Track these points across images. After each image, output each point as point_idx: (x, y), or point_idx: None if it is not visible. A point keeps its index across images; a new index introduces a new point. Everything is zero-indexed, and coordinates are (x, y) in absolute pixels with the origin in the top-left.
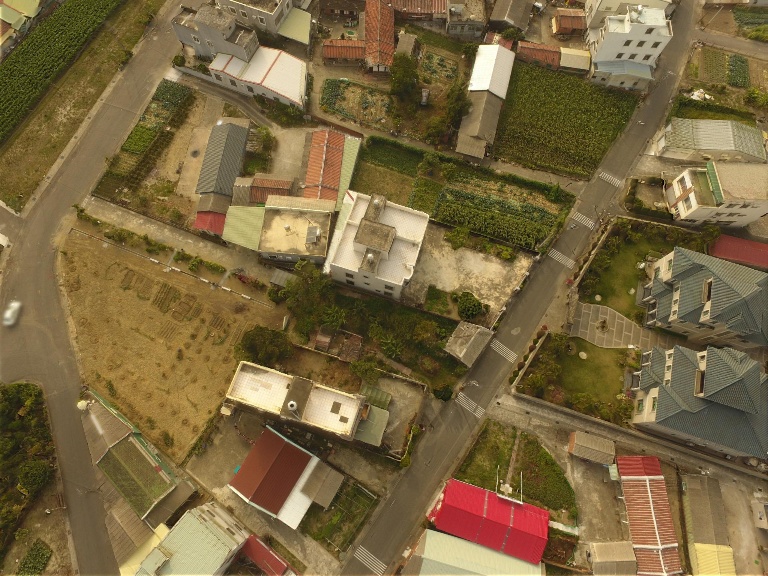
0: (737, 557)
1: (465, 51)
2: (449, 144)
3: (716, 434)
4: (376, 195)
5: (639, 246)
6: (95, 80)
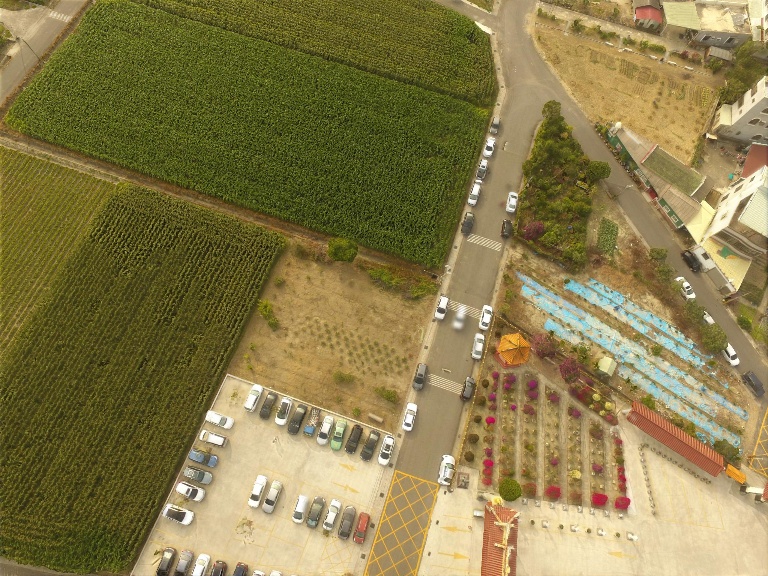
0: None
1: None
2: None
3: None
4: None
5: None
6: None
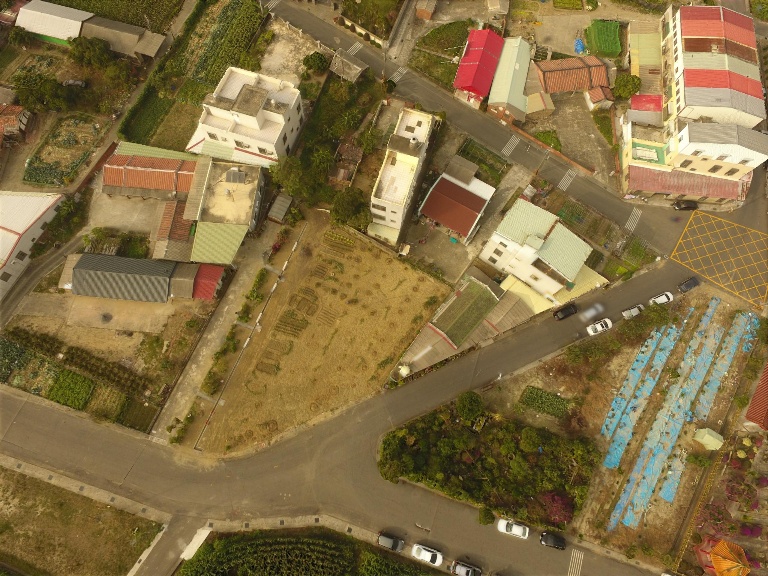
0: None
1: (19, 41)
2: (140, 69)
3: None
4: (205, 101)
5: None
6: None
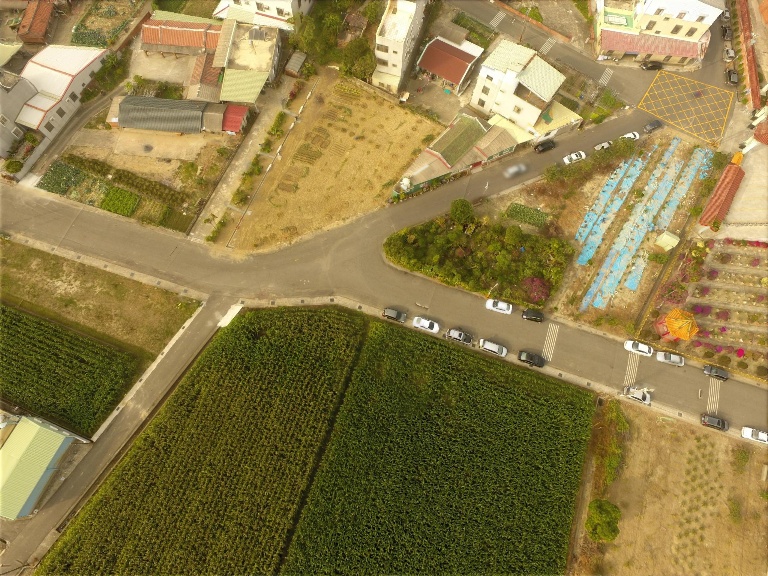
0: None
1: None
2: None
3: None
4: None
5: None
6: (19, 262)
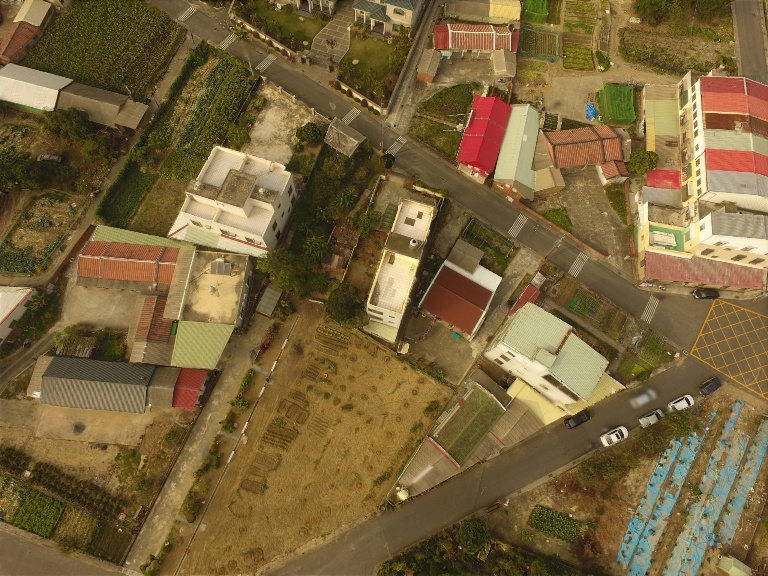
0: None
1: None
2: (121, 140)
3: None
4: (188, 188)
5: (260, 6)
6: None
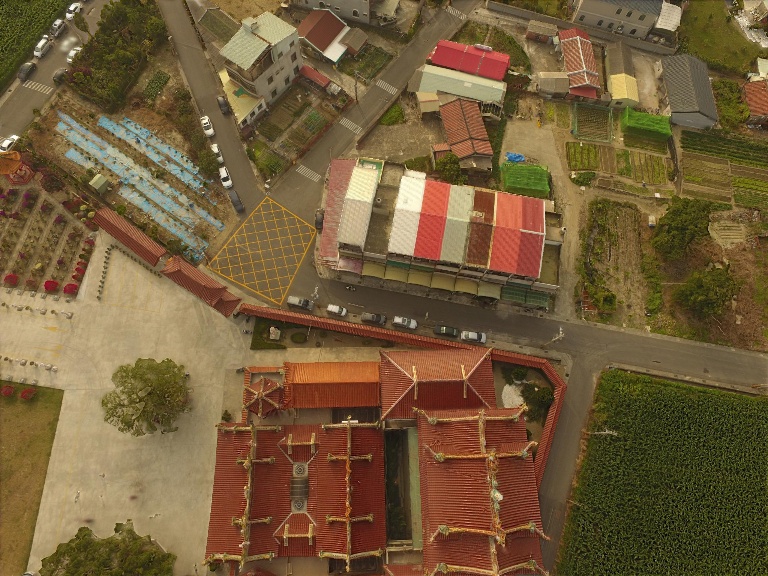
0: (641, 93)
1: None
2: None
3: (625, 0)
4: None
5: None
6: None
